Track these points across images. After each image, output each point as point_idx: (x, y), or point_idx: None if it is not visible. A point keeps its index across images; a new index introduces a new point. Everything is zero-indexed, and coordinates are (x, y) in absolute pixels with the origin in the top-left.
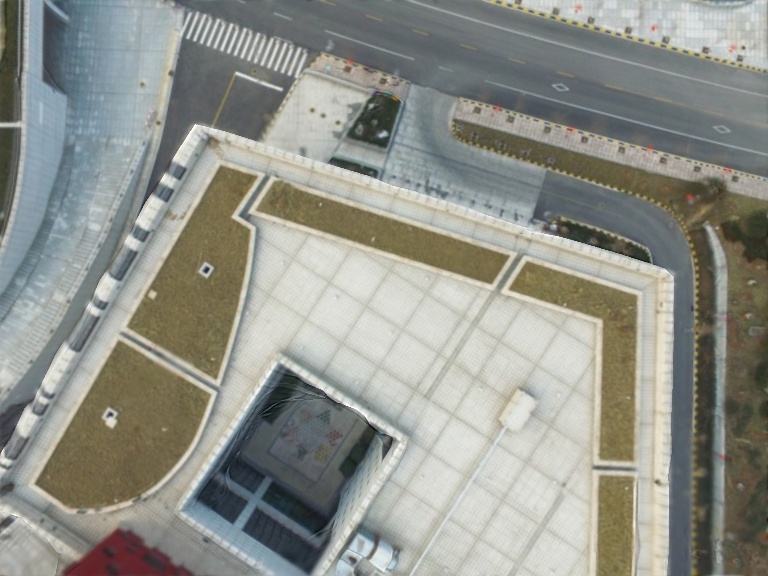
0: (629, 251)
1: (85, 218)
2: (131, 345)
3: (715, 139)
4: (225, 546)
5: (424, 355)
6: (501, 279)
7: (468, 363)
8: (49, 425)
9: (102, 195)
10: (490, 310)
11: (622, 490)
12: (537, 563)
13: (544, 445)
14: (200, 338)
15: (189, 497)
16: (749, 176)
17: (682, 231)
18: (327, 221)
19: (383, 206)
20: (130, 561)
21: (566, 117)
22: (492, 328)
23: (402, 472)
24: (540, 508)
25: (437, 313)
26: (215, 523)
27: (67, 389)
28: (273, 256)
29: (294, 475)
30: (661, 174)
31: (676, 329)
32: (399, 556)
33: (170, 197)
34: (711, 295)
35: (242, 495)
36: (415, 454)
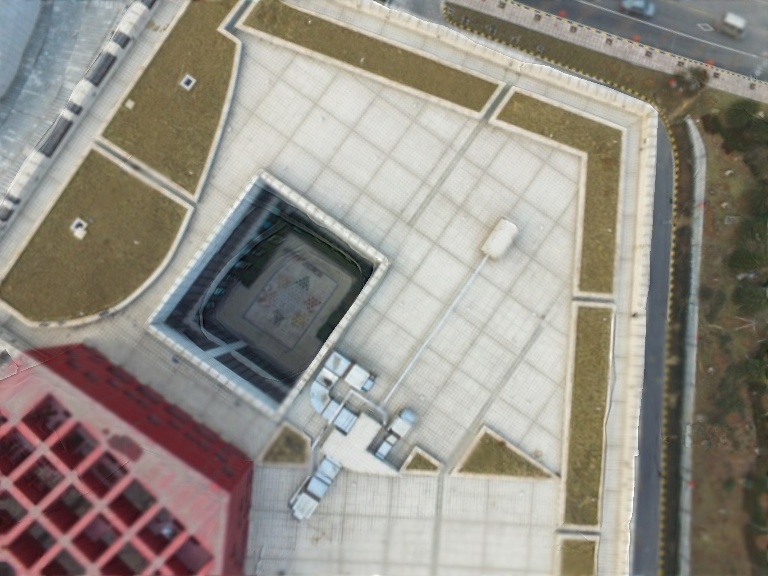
0: None
1: (61, 77)
2: (105, 154)
3: (699, 36)
4: (196, 362)
5: (409, 182)
6: (489, 108)
7: (453, 192)
8: (13, 234)
9: (80, 54)
10: (477, 141)
11: (600, 321)
12: (514, 394)
13: (525, 277)
14: (179, 151)
15: (160, 310)
16: (730, 73)
17: (664, 125)
18: (316, 39)
19: (373, 30)
20: (95, 367)
21: (556, 7)
22: (478, 159)
23: (382, 298)
24: (519, 339)
25: (423, 141)
26: (186, 342)
27: (34, 198)
28: (258, 74)
29: (269, 340)
30: (646, 67)
31: (655, 220)
32: (375, 381)
33: (153, 4)
34: (689, 187)
35: (215, 341)
36: (396, 280)
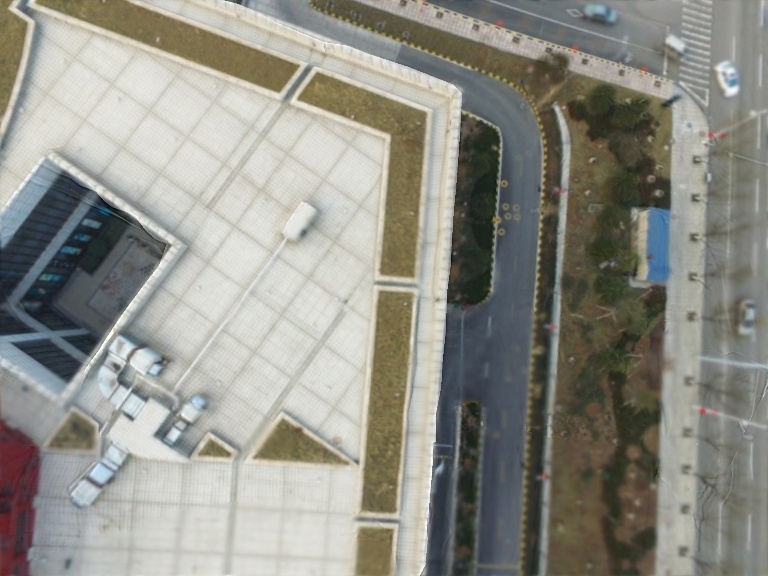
0: (479, 129)
1: None
2: None
3: (568, 22)
4: None
5: (208, 164)
6: (289, 88)
7: (254, 174)
8: None
9: None
10: (279, 122)
11: (401, 305)
12: (314, 380)
13: (327, 261)
14: None
15: None
16: (598, 60)
17: (533, 112)
18: (110, 18)
19: (173, 9)
20: None
21: None
22: (280, 140)
23: (178, 282)
24: (320, 324)
25: (224, 122)
26: None
27: None
28: (53, 54)
29: None
30: (513, 53)
31: (522, 209)
32: (168, 366)
33: None
34: (557, 175)
35: (36, 327)
36: (193, 264)
